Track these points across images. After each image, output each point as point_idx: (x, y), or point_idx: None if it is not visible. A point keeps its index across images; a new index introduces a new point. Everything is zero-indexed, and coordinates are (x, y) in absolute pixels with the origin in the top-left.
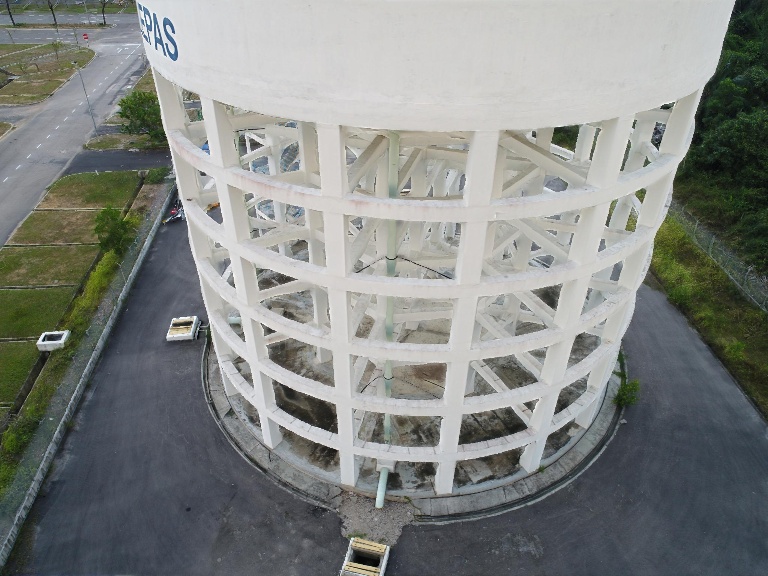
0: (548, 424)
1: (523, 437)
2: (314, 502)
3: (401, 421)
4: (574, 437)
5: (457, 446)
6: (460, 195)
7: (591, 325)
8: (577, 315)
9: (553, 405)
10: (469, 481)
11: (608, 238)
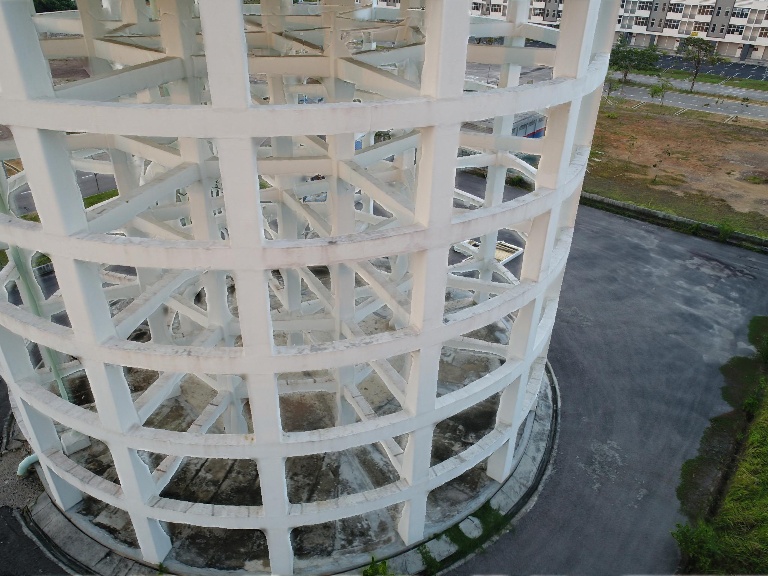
0: (137, 497)
1: (106, 490)
2: (6, 432)
3: (147, 421)
4: (245, 571)
5: (40, 443)
6: (172, 148)
7: (133, 362)
8: (85, 324)
9: (128, 467)
10: (93, 515)
11: (390, 307)
